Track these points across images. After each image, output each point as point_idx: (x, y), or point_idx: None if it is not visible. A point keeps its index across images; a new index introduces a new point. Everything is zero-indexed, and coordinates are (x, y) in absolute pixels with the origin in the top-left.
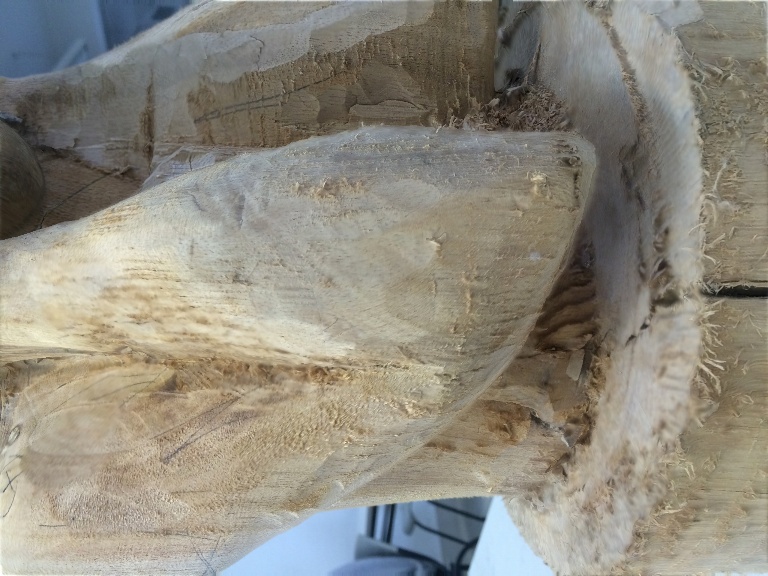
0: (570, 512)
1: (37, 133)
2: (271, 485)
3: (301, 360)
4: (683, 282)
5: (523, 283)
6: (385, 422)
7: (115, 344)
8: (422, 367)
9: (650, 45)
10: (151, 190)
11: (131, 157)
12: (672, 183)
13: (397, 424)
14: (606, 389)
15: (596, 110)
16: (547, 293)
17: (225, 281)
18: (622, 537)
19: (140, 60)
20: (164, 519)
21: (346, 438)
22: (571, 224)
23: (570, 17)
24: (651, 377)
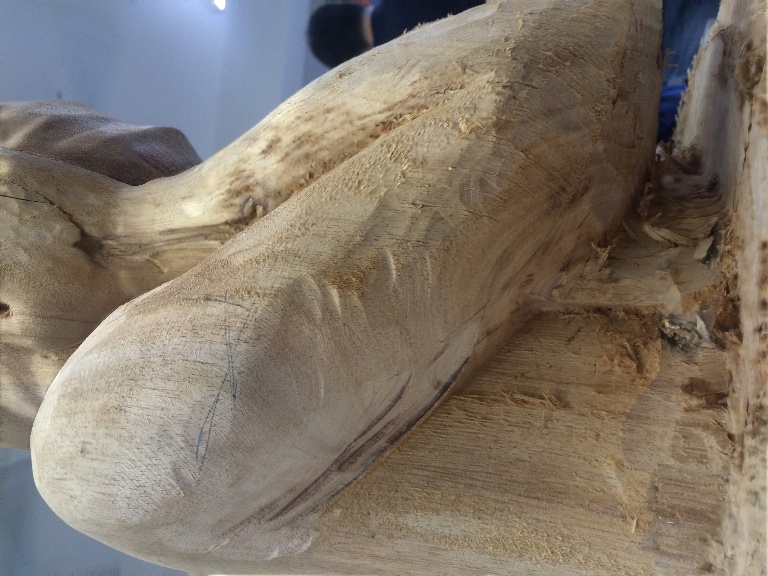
0: (746, 486)
1: None
2: (319, 235)
3: (376, 120)
4: (764, 39)
5: (578, 27)
6: (439, 147)
7: (242, 196)
8: (476, 81)
9: (725, 4)
10: None
11: None
12: (746, 16)
13: (450, 148)
14: (740, 243)
15: (706, 99)
16: (617, 72)
17: (334, 82)
18: None
19: None
20: (211, 284)
21: (400, 171)
22: (629, 8)
23: (691, 104)
24: (761, 139)
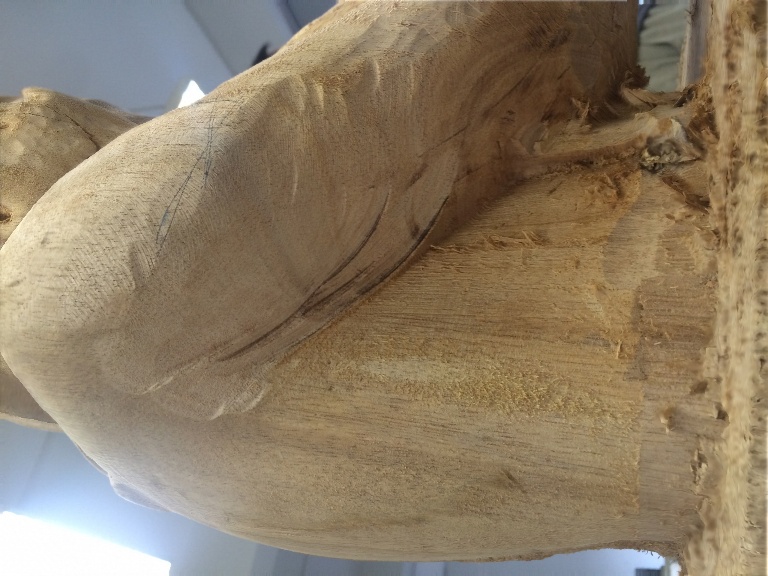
0: None
1: None
2: None
3: None
4: None
5: None
6: None
7: None
8: None
9: None
10: None
11: None
12: None
13: None
14: (712, 73)
15: None
16: None
17: None
18: (752, 65)
19: None
20: None
21: (393, 3)
22: None
23: None
24: None
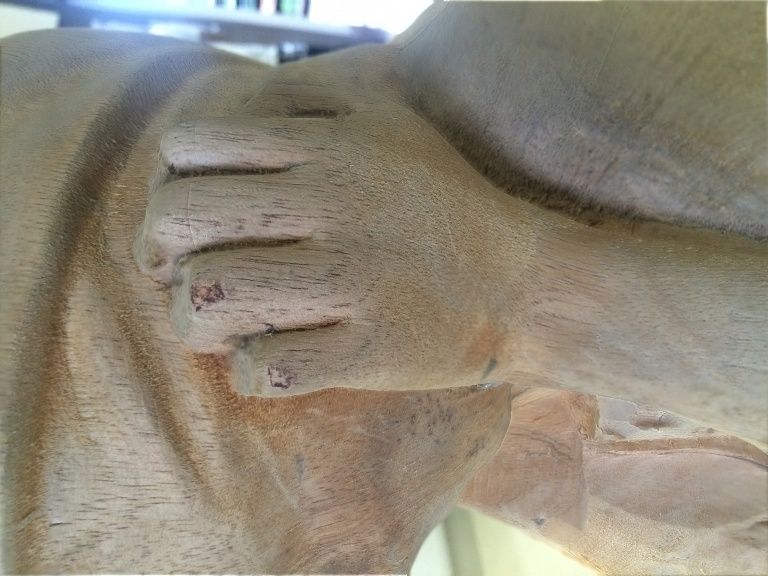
0: None
1: None
2: None
3: None
4: None
5: None
6: None
7: None
8: None
9: None
10: (620, 569)
11: None
12: None
13: None
14: None
15: None
16: None
17: None
18: None
19: None
20: None
21: None
22: None
23: None
24: None
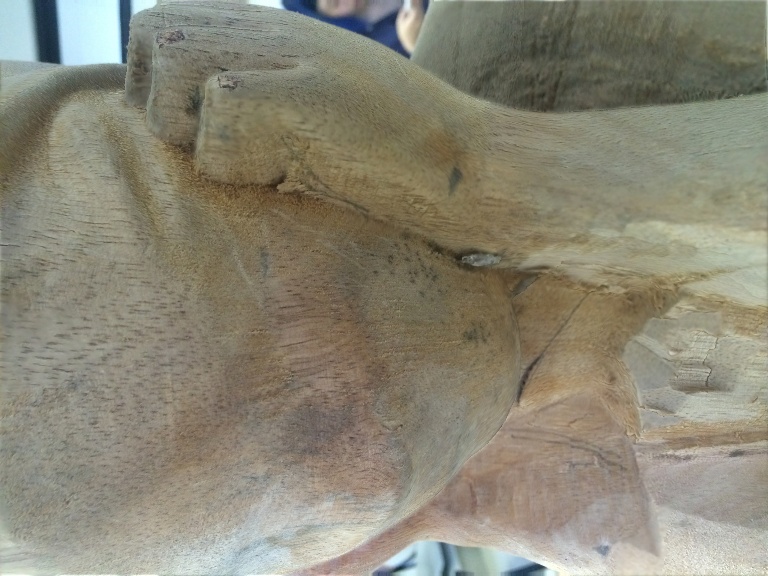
0: None
1: (513, 258)
2: None
3: None
4: None
5: None
6: None
7: None
8: None
9: None
10: None
11: (632, 280)
12: None
13: None
14: None
15: None
16: None
17: None
18: None
19: (741, 255)
20: None
21: None
22: None
23: None
24: None
